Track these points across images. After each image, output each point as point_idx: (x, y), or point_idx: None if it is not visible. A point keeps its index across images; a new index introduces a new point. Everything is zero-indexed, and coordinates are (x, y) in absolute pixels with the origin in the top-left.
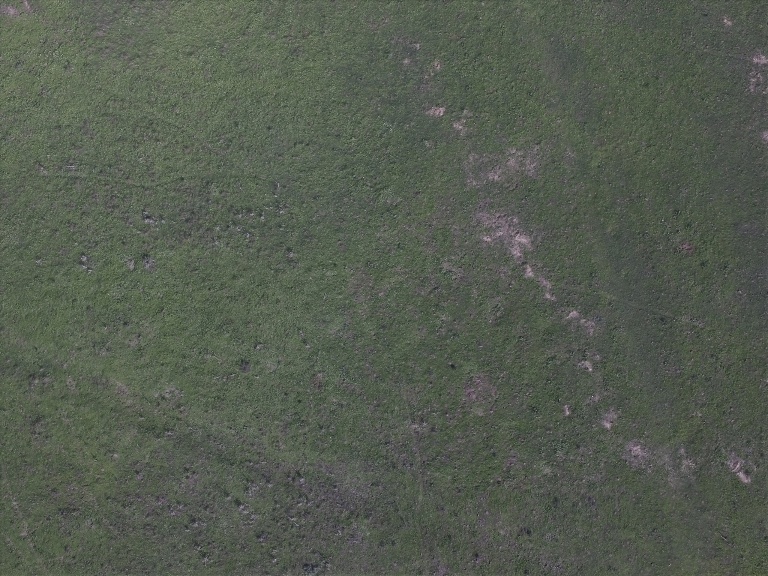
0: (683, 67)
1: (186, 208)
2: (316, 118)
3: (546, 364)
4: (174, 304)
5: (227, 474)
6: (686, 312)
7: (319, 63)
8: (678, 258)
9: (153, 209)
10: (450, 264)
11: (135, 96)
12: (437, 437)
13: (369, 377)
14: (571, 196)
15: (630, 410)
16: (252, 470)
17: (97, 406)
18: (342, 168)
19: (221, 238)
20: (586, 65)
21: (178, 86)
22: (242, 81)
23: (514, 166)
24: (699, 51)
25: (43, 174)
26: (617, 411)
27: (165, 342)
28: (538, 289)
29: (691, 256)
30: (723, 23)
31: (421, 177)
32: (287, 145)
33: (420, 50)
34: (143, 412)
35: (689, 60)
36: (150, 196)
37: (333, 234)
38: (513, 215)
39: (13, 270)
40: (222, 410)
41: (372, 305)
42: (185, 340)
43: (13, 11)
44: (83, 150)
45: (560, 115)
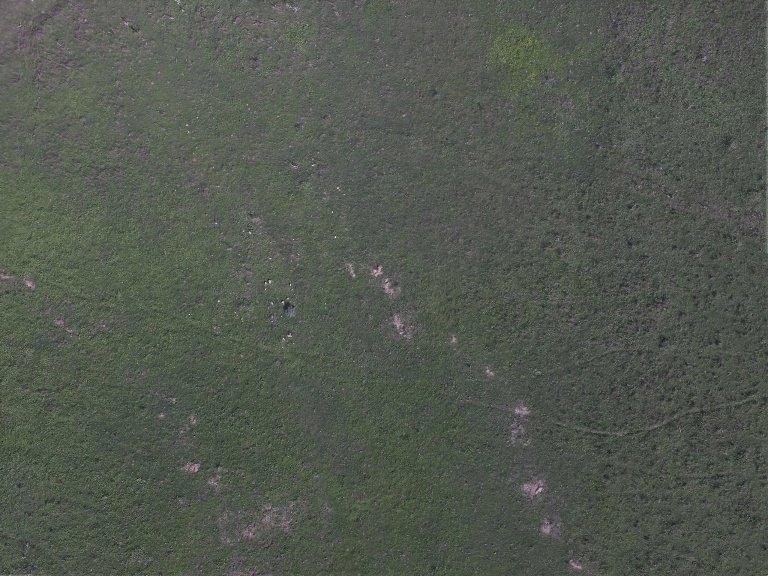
0: (444, 418)
1: None
2: (68, 474)
3: None
4: None
5: None
6: None
7: (73, 418)
8: None
9: None
10: None
11: None
12: None
13: None
14: (328, 552)
15: None
16: None
17: None
18: (94, 526)
19: None
20: (346, 417)
21: None
22: None
23: (270, 522)
24: (461, 401)
25: None
26: None
27: None
28: None
29: None
30: (486, 373)
31: (174, 536)
32: (38, 503)
33: (176, 404)
34: None
35: (450, 411)
36: None
37: None
38: (268, 573)
39: None
40: None
41: None
42: None
43: None
44: None
45: (318, 469)
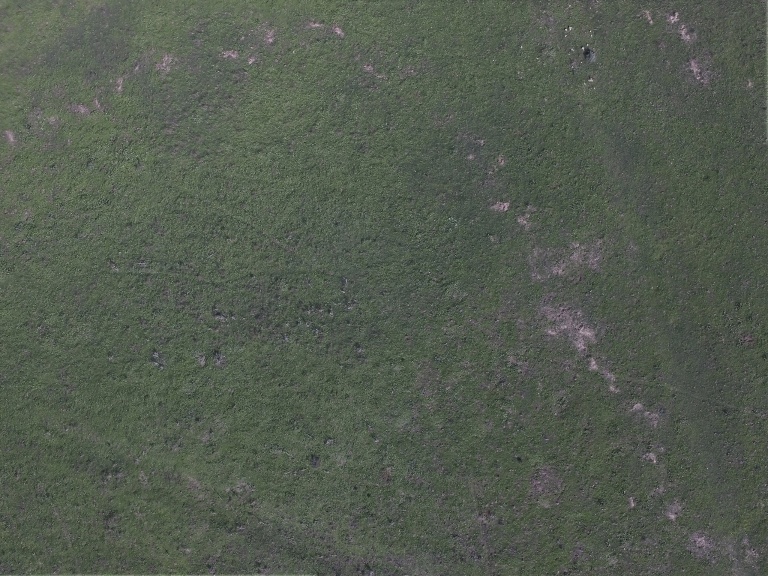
0: (743, 160)
1: (255, 304)
2: (382, 214)
3: (611, 456)
4: (245, 400)
5: (298, 568)
6: (748, 403)
7: (385, 159)
8: (740, 350)
9: (223, 305)
10: (516, 358)
11: (204, 193)
12: (504, 529)
13: (437, 470)
14: (634, 289)
15: (694, 501)
16: (322, 564)
17: (169, 501)
18: (408, 263)
19: (291, 334)
20: (647, 159)
21: (246, 183)
22: (309, 178)
23: (578, 260)
24: (758, 144)
25: (114, 271)
26: (681, 502)
27: (236, 438)
28: (602, 382)
29: (753, 348)
30: None
31: (486, 272)
32: (354, 241)
33: (484, 146)
34: (215, 507)
35: (749, 153)
36: (220, 292)
37: (400, 329)
38: (577, 308)
39: (86, 366)
40: (293, 505)
41: (439, 399)
42: (256, 436)
43: (84, 110)
44: (154, 247)
45: (622, 209)
